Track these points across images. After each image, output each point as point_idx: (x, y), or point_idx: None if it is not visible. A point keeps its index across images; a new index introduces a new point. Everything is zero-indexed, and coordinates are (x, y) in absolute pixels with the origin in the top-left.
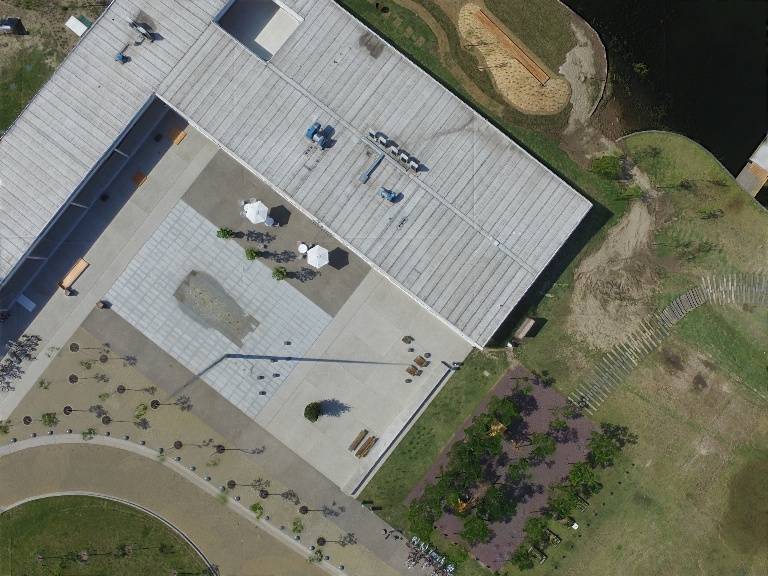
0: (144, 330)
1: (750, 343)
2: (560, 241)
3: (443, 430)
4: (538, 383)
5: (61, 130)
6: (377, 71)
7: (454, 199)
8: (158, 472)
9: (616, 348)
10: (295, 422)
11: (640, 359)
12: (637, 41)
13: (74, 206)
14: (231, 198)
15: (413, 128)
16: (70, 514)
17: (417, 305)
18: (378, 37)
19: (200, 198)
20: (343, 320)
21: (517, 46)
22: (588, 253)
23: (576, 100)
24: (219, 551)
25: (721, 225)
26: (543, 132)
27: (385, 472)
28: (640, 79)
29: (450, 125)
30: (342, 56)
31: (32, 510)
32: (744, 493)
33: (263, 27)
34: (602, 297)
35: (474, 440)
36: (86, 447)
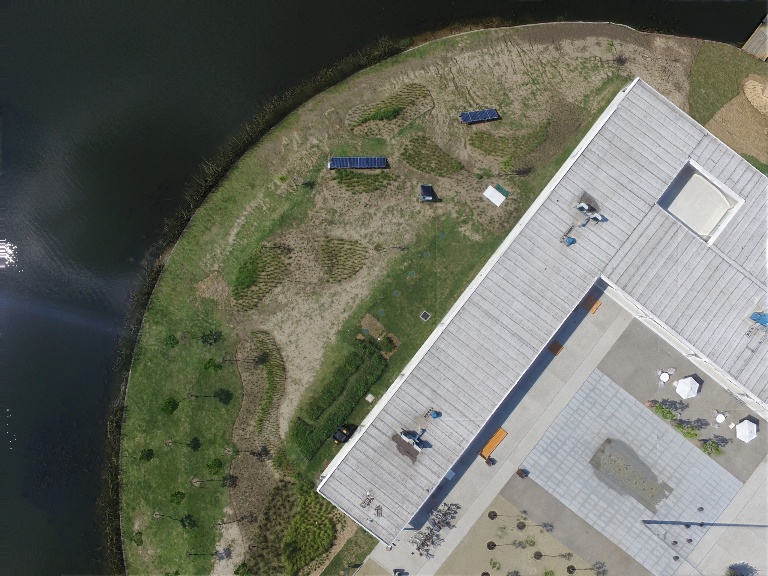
0: (561, 497)
1: None
2: None
3: None
4: None
5: (509, 313)
6: None
7: None
8: None
9: None
10: None
11: None
12: None
13: None
14: (645, 367)
15: None
16: None
17: None
18: None
19: (615, 367)
20: (753, 486)
21: None
22: None
23: None
24: None
25: None
26: None
27: None
28: None
29: None
30: None
31: None
32: None
33: (676, 196)
34: None
35: None
36: None
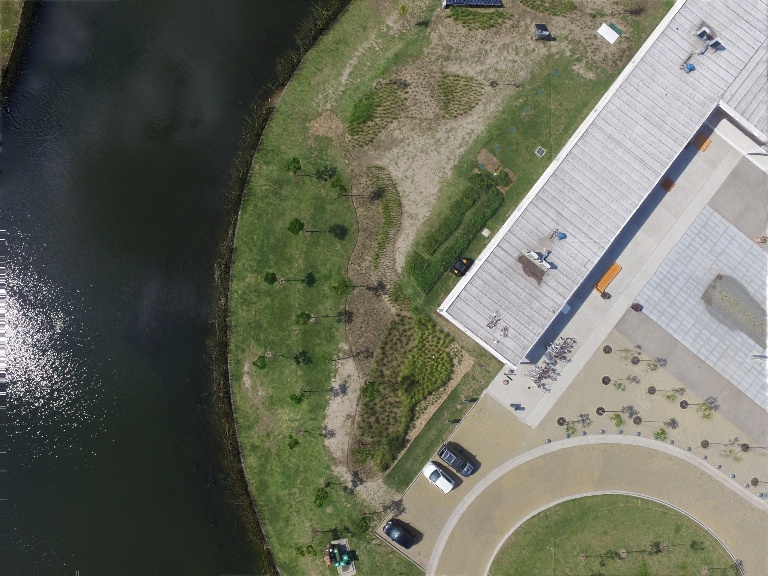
0: (674, 332)
1: None
2: None
3: None
4: None
5: (632, 136)
6: None
7: None
8: (686, 470)
9: None
10: None
11: None
12: None
13: None
14: (754, 204)
15: None
16: (608, 513)
17: None
18: None
19: (725, 204)
20: None
21: None
22: None
23: None
24: (743, 546)
25: None
26: None
27: None
28: None
29: None
30: None
31: (571, 510)
32: None
33: None
34: None
35: None
36: (618, 447)
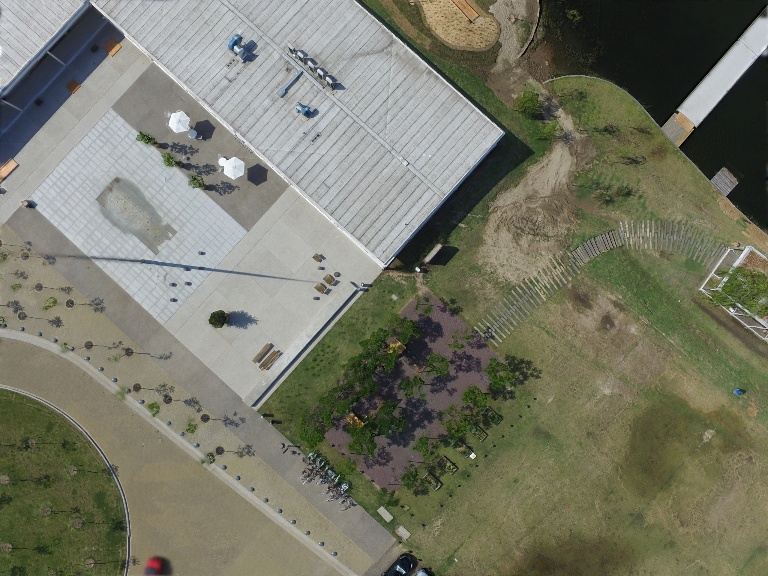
0: (65, 231)
1: (665, 290)
2: (469, 166)
3: (348, 350)
4: (445, 311)
5: None
6: None
7: (368, 118)
8: (67, 370)
9: (525, 282)
10: (203, 331)
11: (549, 294)
12: None
13: (6, 105)
14: (159, 110)
15: (333, 48)
16: None
17: (331, 225)
18: None
19: (129, 108)
20: (257, 235)
21: None
22: (505, 188)
23: (505, 40)
24: (120, 452)
25: (642, 171)
26: (470, 68)
27: (288, 387)
28: (572, 25)
29: (369, 47)
30: None
31: None
32: (647, 437)
33: None
34: (515, 231)
35: (368, 352)
36: (1, 340)
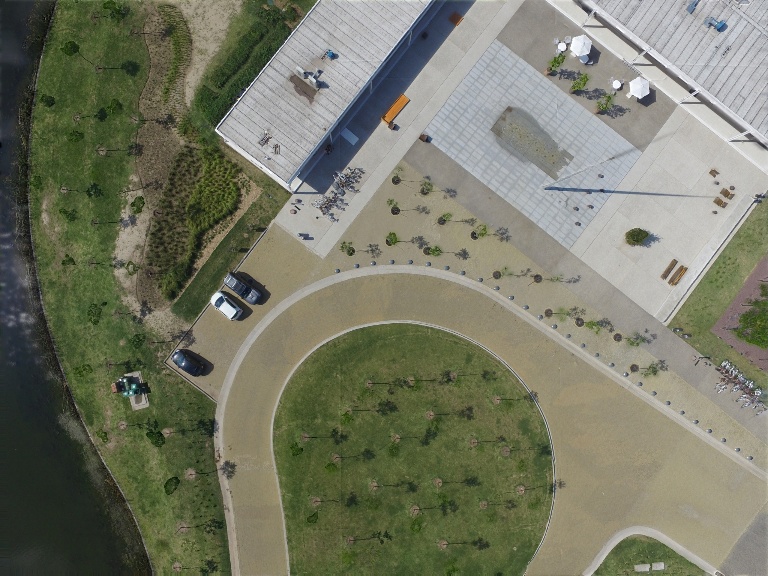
0: (463, 163)
1: None
2: None
3: (746, 260)
4: None
5: None
6: None
7: None
8: (478, 301)
9: None
10: (609, 252)
11: None
12: None
13: (408, 37)
14: (544, 38)
15: None
16: (397, 341)
17: (721, 141)
18: None
19: (514, 38)
20: (652, 154)
21: None
22: None
23: None
24: (538, 378)
25: None
26: None
27: (694, 300)
28: None
29: None
30: None
31: (359, 338)
32: None
33: None
34: None
35: None
36: (408, 277)
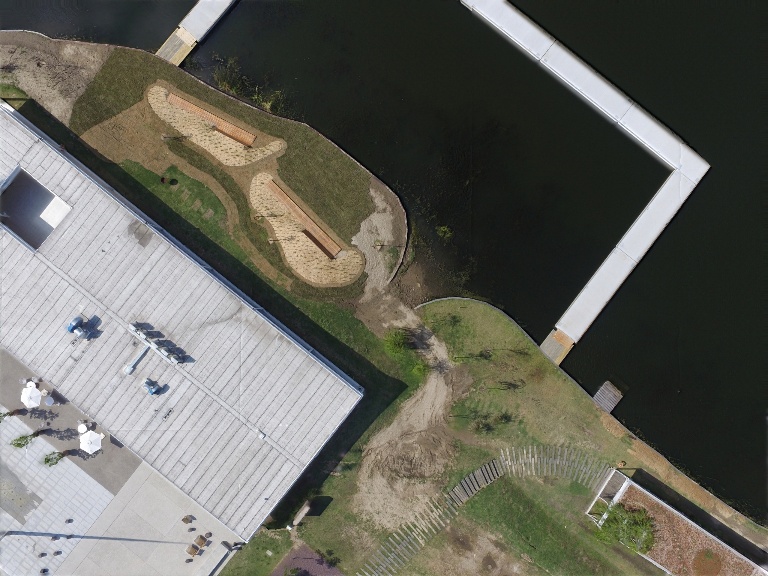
0: None
1: (550, 517)
2: (327, 433)
3: None
4: (322, 563)
5: None
6: (145, 260)
7: (220, 390)
8: None
9: (403, 528)
10: None
11: (427, 539)
12: (441, 203)
13: None
14: (15, 375)
15: (180, 318)
16: None
17: None
18: (146, 225)
19: None
20: (125, 498)
21: (309, 217)
22: (378, 429)
23: (372, 269)
24: None
25: (521, 396)
26: (336, 303)
27: None
28: (443, 243)
29: (218, 315)
30: (110, 245)
31: None
32: None
33: (48, 203)
34: (390, 475)
35: None
36: None
